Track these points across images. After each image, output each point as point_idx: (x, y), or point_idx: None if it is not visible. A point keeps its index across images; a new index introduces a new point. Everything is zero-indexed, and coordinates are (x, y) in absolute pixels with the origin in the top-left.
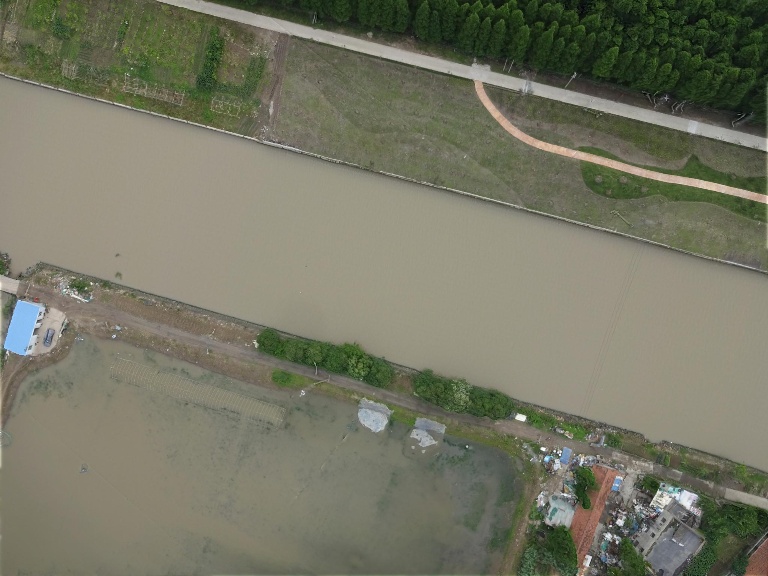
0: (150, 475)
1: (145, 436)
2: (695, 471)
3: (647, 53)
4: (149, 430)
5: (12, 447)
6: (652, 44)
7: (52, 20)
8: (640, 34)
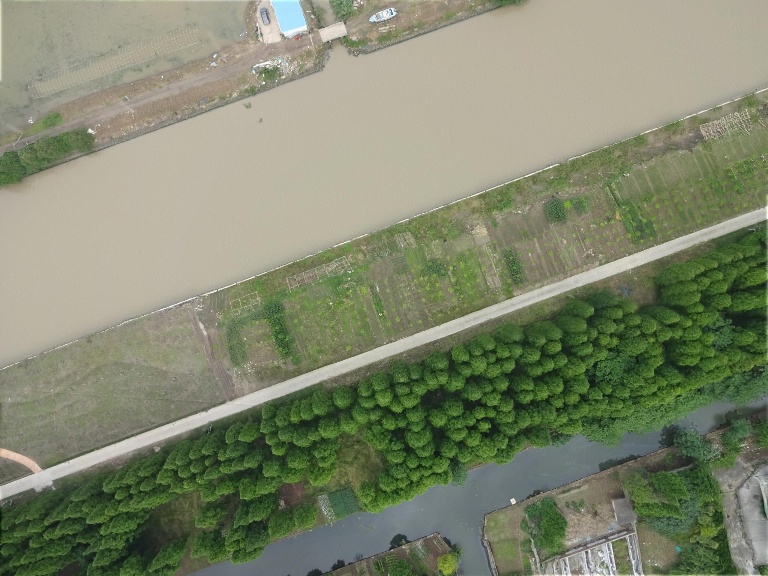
0: None
1: None
2: None
3: None
4: (136, 7)
5: None
6: None
7: (450, 272)
8: None
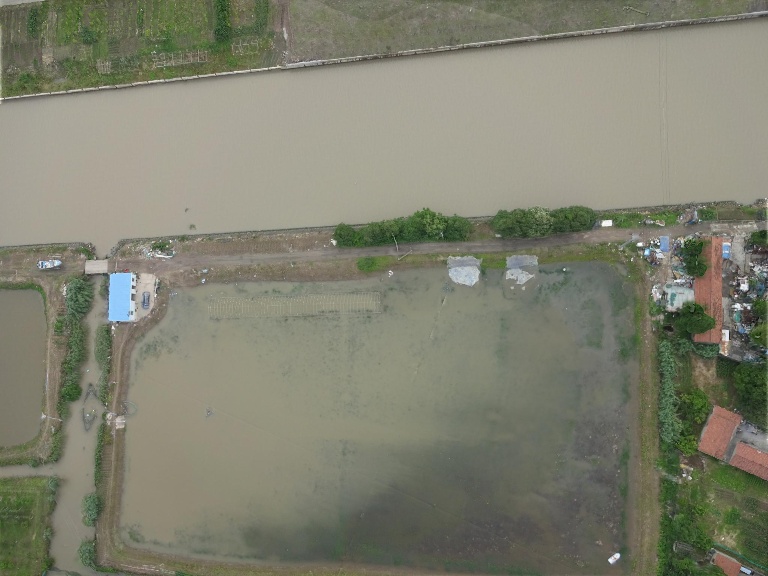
0: (272, 397)
1: (257, 362)
2: None
3: None
4: (259, 356)
5: (139, 414)
6: None
7: (79, 31)
8: None
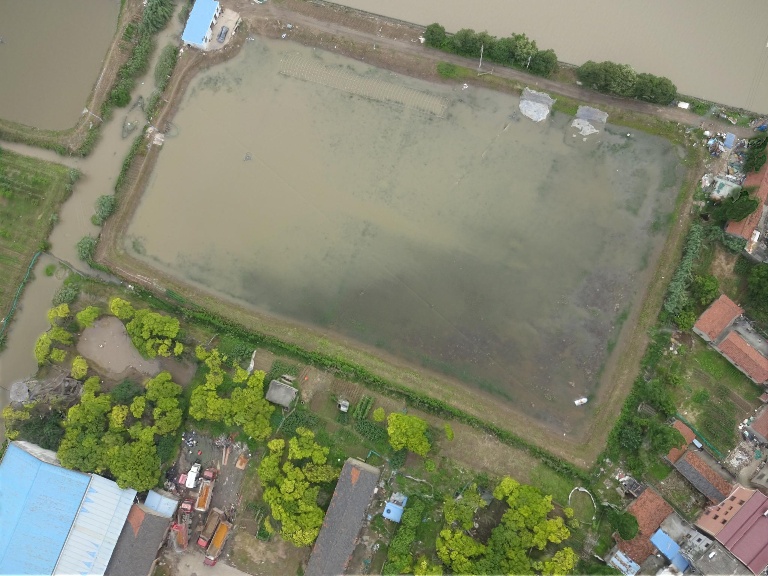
0: (313, 163)
1: (309, 127)
2: None
3: None
4: (313, 121)
5: (179, 137)
6: None
7: None
8: None
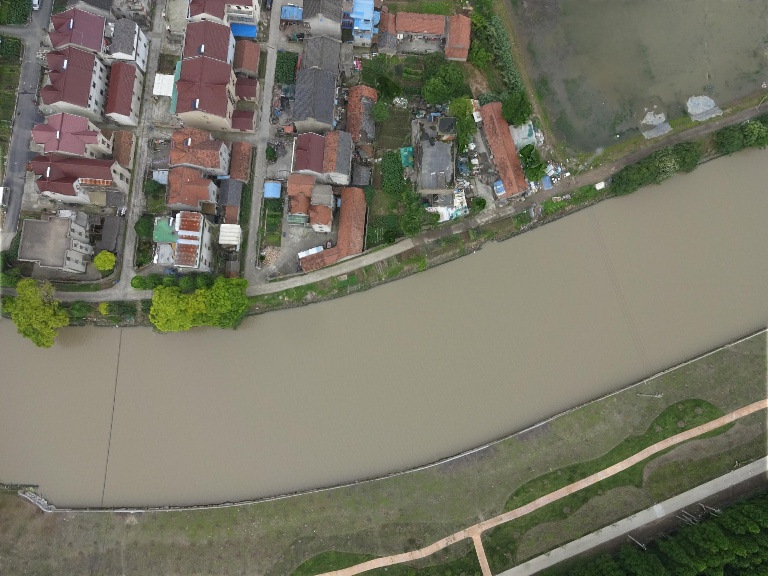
0: None
1: None
2: (446, 242)
3: None
4: None
5: None
6: None
7: None
8: None
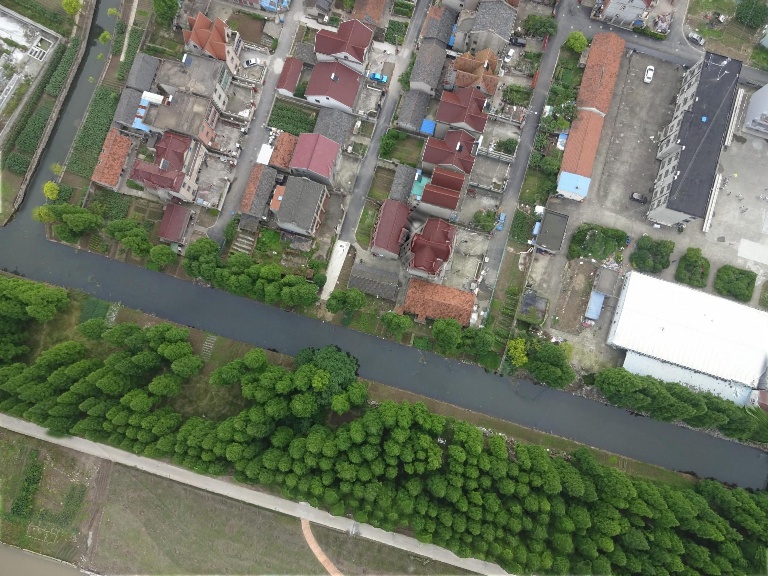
0: None
1: None
2: None
3: (461, 539)
4: None
5: None
6: (465, 532)
7: None
8: (453, 521)
